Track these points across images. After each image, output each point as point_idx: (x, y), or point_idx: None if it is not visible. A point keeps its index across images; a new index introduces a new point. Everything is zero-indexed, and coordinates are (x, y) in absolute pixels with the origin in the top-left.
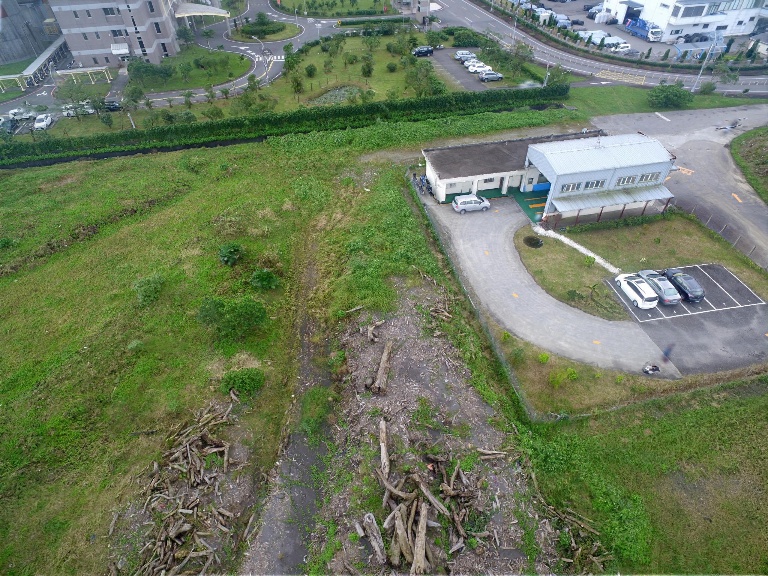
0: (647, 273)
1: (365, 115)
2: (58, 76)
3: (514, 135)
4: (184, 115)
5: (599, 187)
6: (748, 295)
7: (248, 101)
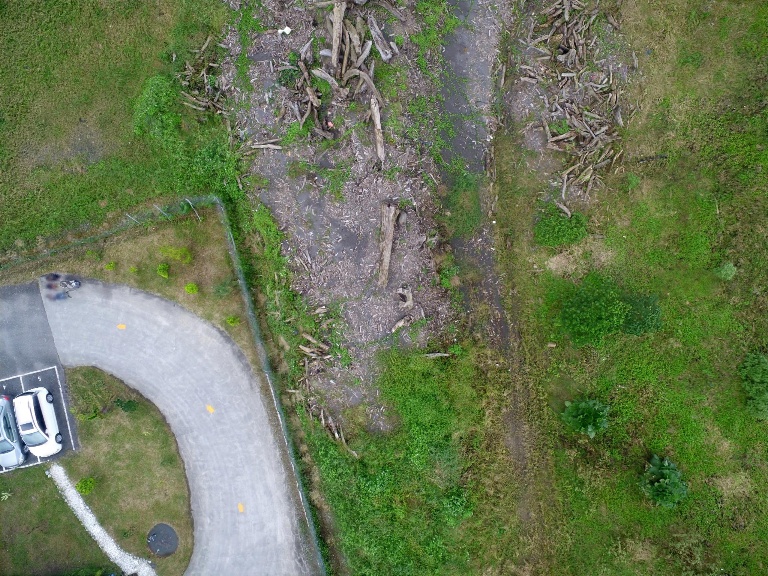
0: (11, 456)
1: None
2: None
3: None
4: None
5: None
6: None
7: None
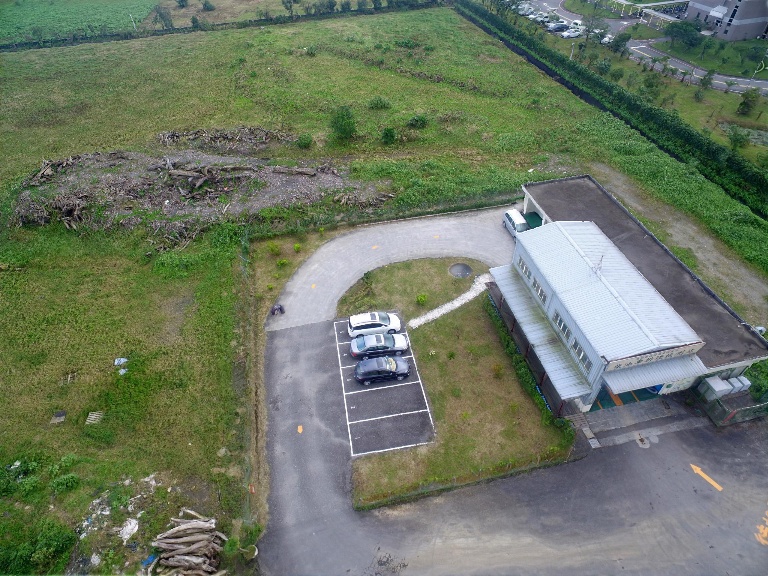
0: (397, 336)
1: (704, 155)
2: (602, 4)
3: (765, 291)
4: (599, 64)
5: (542, 300)
6: (368, 442)
7: (652, 81)
